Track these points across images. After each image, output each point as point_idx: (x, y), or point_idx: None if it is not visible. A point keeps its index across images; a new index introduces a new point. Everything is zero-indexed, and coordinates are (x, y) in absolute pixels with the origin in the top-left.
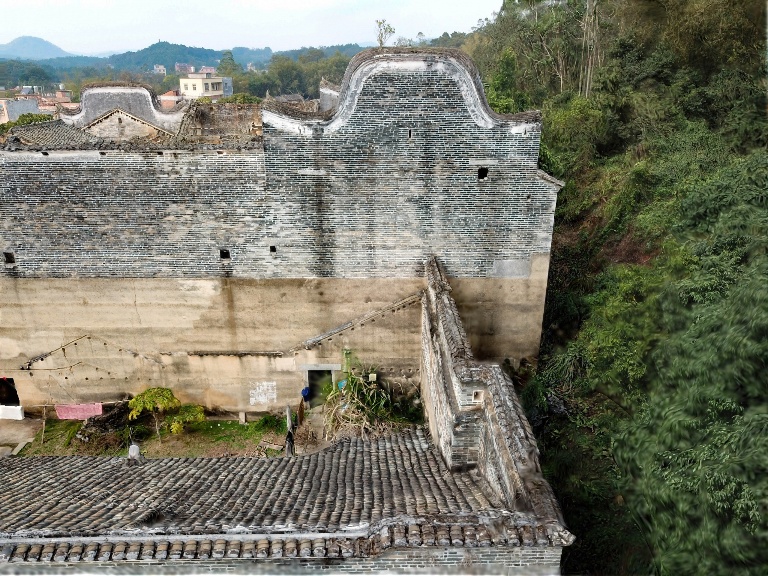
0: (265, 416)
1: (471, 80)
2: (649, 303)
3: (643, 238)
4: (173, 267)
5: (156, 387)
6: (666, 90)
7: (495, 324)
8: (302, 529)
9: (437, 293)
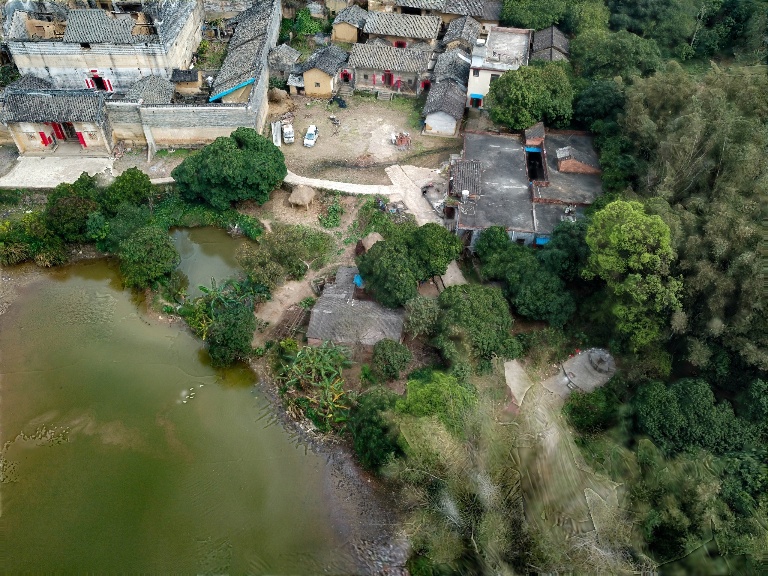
0: None
1: None
2: None
3: None
4: None
5: None
6: None
7: None
8: None
9: None
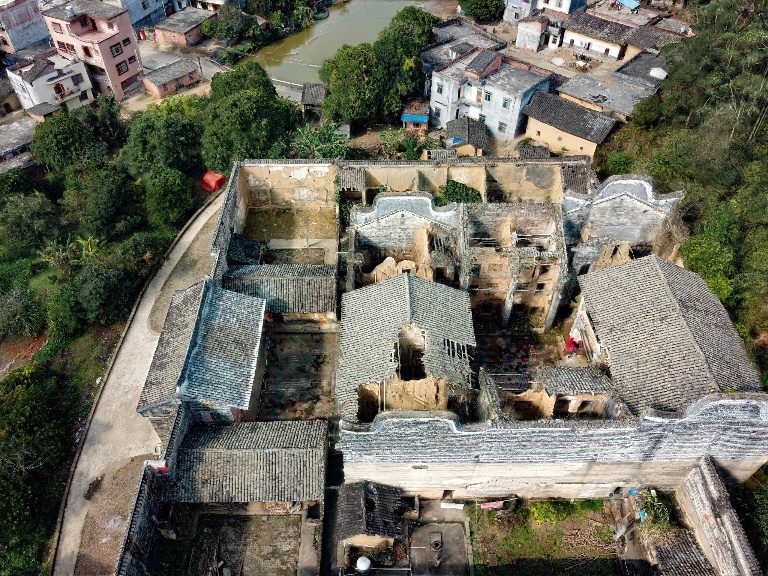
0: (585, 501)
1: None
2: None
3: None
4: (565, 459)
5: (531, 492)
6: None
7: (729, 474)
8: None
9: (721, 497)
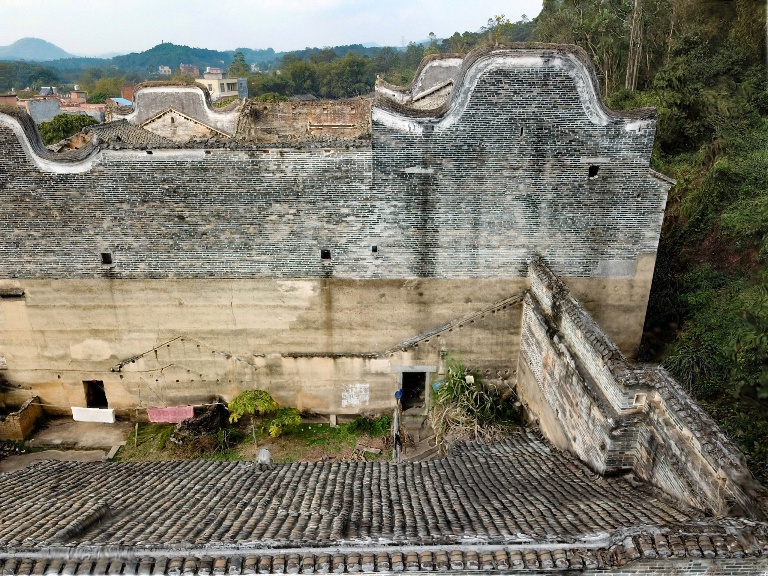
0: (356, 419)
1: (588, 76)
2: None
3: (731, 237)
4: (272, 267)
5: (247, 389)
6: (738, 87)
7: None
8: (538, 539)
9: (554, 293)
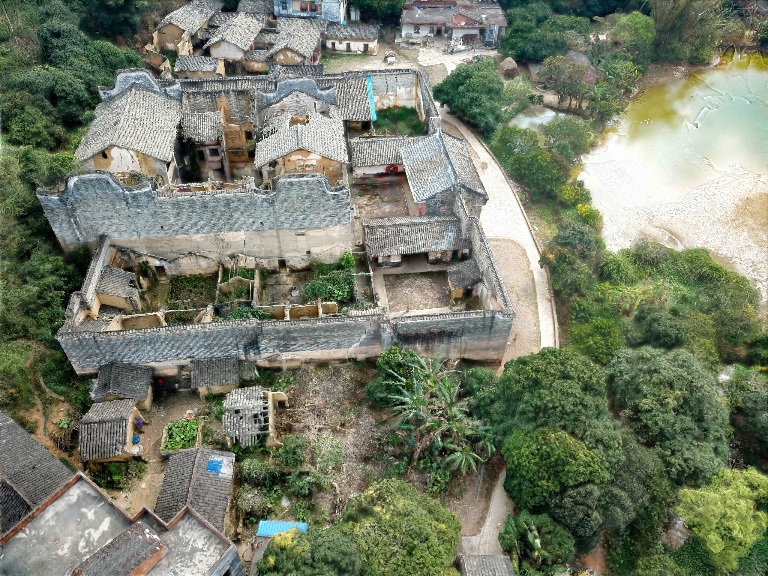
0: None
1: None
2: None
3: None
4: None
5: None
6: None
7: None
8: (181, 80)
9: None
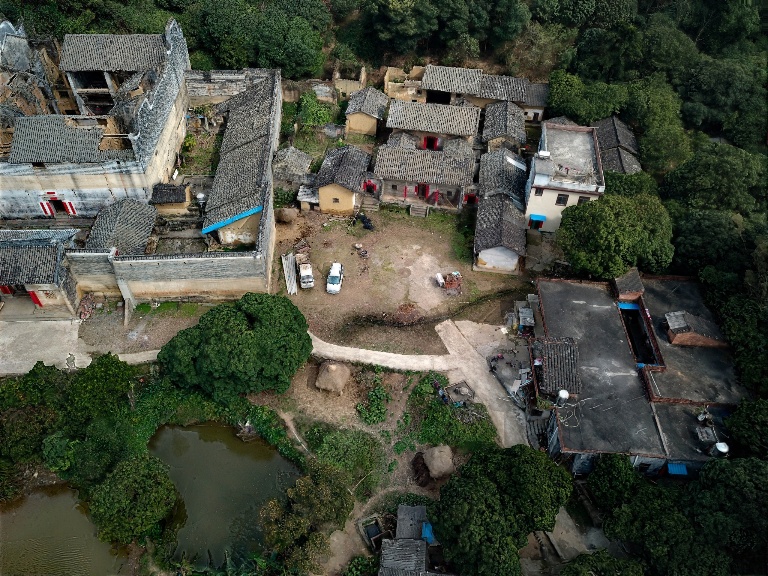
0: None
1: None
2: (239, 48)
3: None
4: None
5: None
6: None
7: None
8: None
9: (203, 73)
